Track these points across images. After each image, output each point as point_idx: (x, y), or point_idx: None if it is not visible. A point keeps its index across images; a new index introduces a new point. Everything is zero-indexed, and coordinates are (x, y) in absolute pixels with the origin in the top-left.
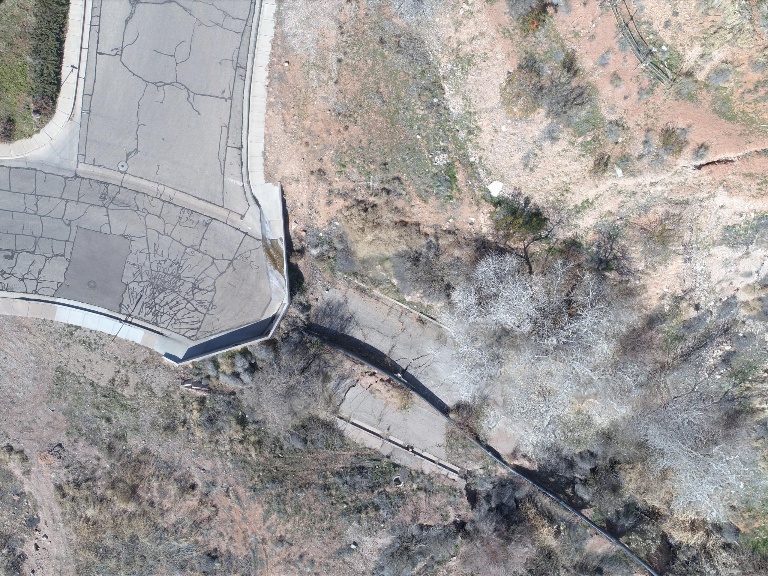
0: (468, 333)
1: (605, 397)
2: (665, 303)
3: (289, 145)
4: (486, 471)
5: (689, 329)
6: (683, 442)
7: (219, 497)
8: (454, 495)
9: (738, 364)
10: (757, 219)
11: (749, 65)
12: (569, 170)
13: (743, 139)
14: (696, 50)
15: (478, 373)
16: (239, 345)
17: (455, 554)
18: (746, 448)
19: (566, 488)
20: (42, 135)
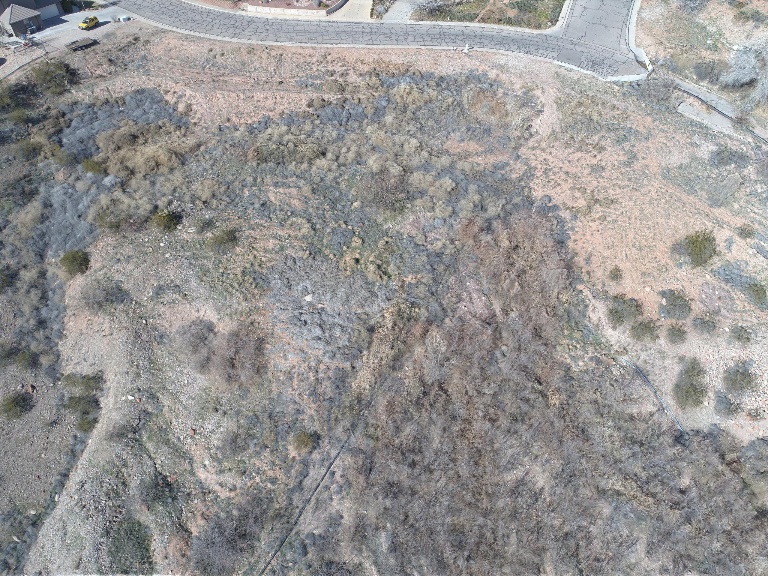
0: None
1: None
2: None
3: (647, 37)
4: None
5: None
6: None
7: (630, 113)
8: None
9: None
10: None
11: None
12: (766, 35)
13: None
14: None
15: None
16: (634, 75)
17: None
18: None
19: None
20: (550, 29)
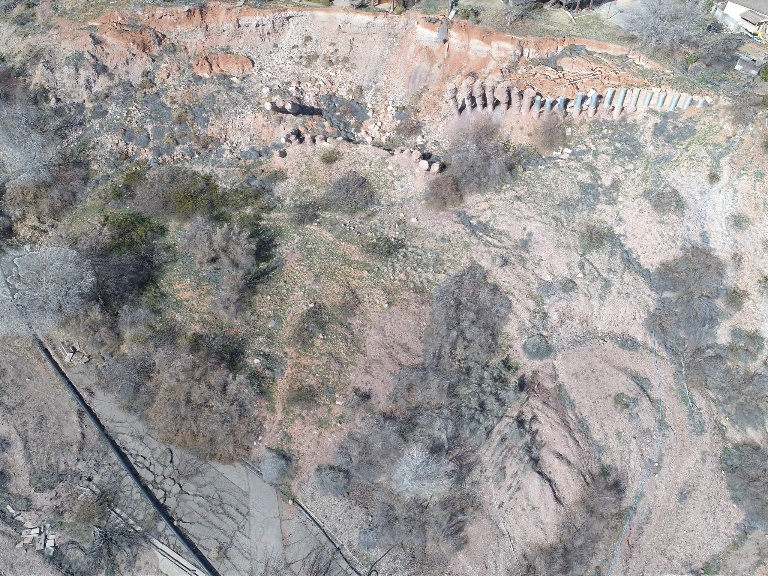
0: None
1: None
2: None
3: None
4: None
5: (56, 113)
6: None
7: None
8: None
9: None
10: (77, 54)
11: None
12: None
13: (71, 23)
14: (70, 6)
15: None
16: None
17: None
18: None
19: None
20: None
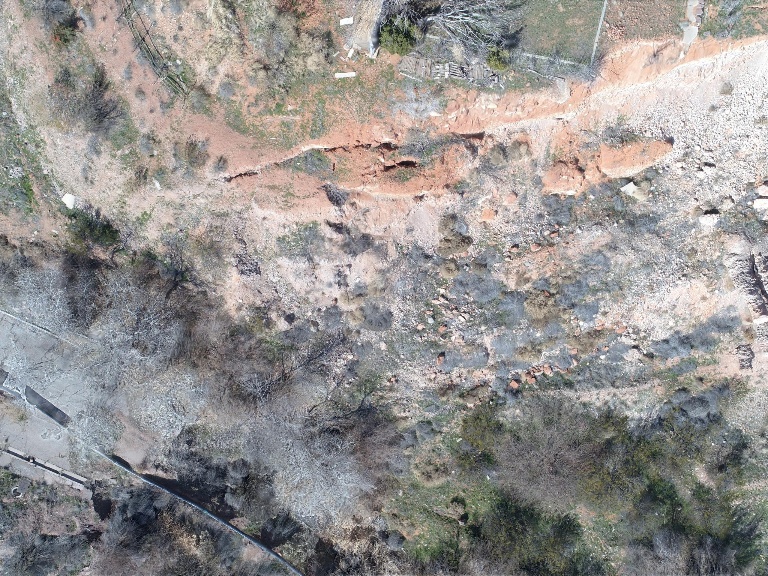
0: (85, 344)
1: (213, 407)
2: (245, 314)
3: None
4: (119, 481)
5: (295, 339)
6: (310, 451)
7: None
8: (79, 505)
9: (363, 373)
10: (302, 231)
11: (247, 79)
12: (119, 183)
13: (256, 152)
14: (203, 64)
15: (92, 384)
16: None
17: (88, 564)
18: (399, 456)
19: (211, 497)
20: None
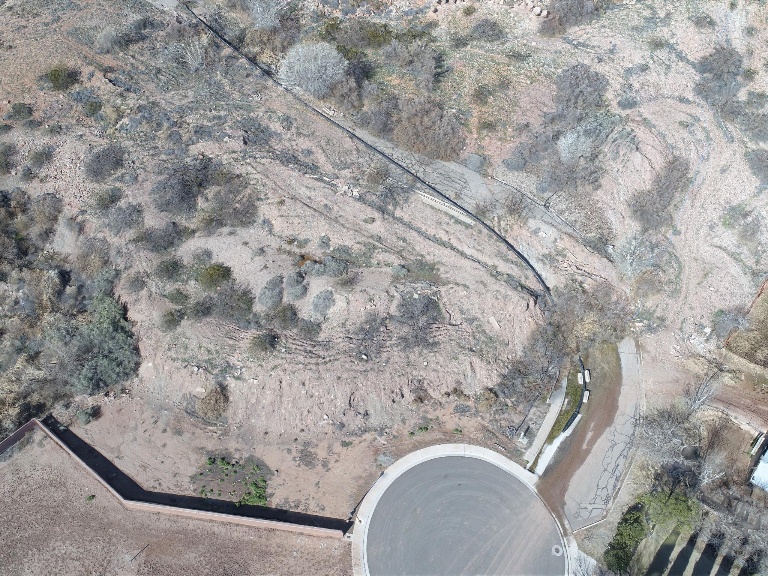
0: None
1: None
2: None
3: None
4: None
5: None
6: None
7: None
8: None
9: (292, 5)
10: None
11: None
12: None
13: None
14: None
15: None
16: None
17: None
18: None
19: None
20: None
